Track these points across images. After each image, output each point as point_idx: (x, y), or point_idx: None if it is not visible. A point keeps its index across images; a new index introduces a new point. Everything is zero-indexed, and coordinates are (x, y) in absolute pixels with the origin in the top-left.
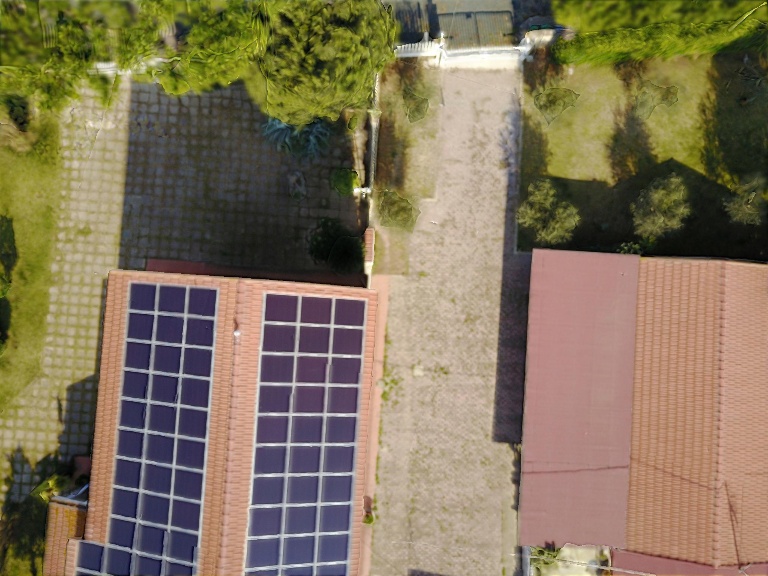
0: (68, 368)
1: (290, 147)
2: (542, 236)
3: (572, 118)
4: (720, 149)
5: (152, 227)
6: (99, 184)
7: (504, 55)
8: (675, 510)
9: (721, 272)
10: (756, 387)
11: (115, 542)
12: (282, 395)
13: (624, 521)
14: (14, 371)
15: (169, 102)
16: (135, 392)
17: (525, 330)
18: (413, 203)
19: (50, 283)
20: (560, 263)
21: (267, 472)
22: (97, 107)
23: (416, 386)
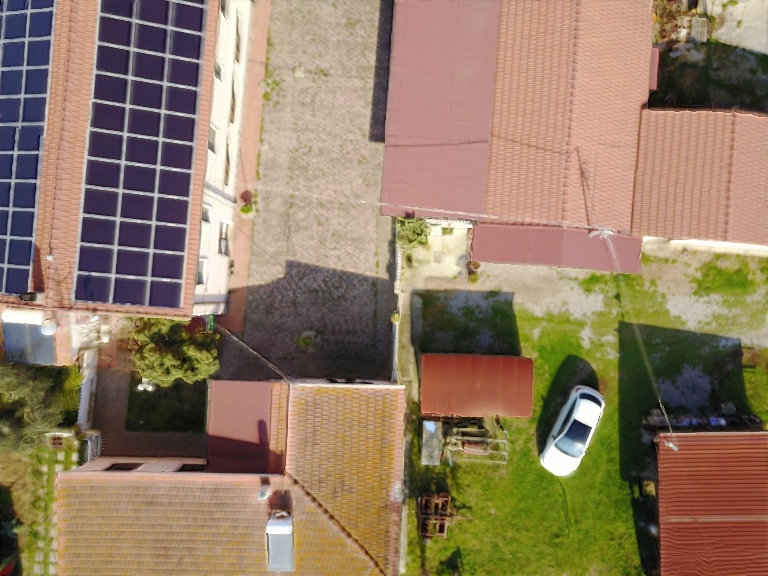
0: None
1: None
2: None
3: None
4: None
5: None
6: None
7: None
8: (530, 179)
9: None
10: (613, 62)
11: None
12: (125, 1)
13: (483, 194)
14: None
15: None
16: None
17: None
18: None
19: None
20: None
21: (110, 71)
22: None
23: (297, 87)
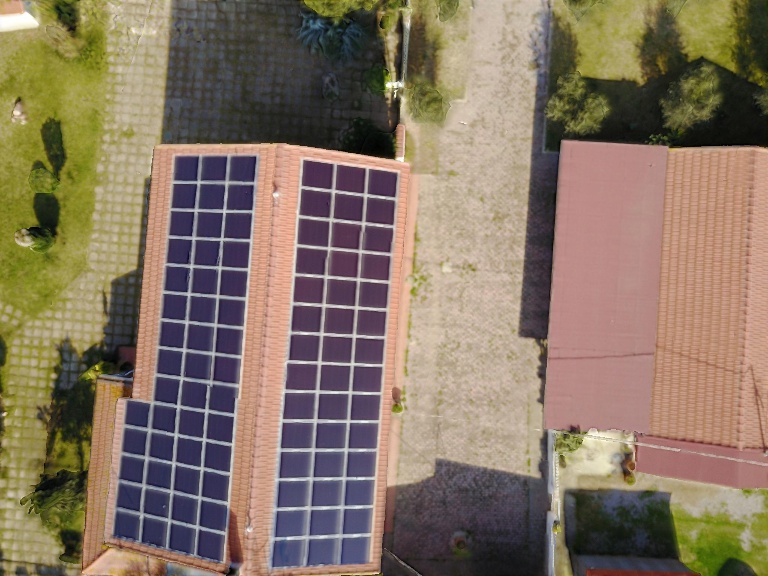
0: (113, 263)
1: (323, 48)
2: (570, 127)
3: (601, 19)
4: (751, 47)
5: (191, 128)
6: (141, 88)
7: None
8: (700, 395)
9: (750, 159)
10: None
11: (161, 399)
12: (318, 258)
13: (649, 407)
14: (62, 265)
15: (207, 8)
16: (179, 258)
17: (552, 228)
18: (443, 98)
19: (95, 182)
20: (588, 154)
21: (304, 330)
22: (139, 14)
23: (445, 282)
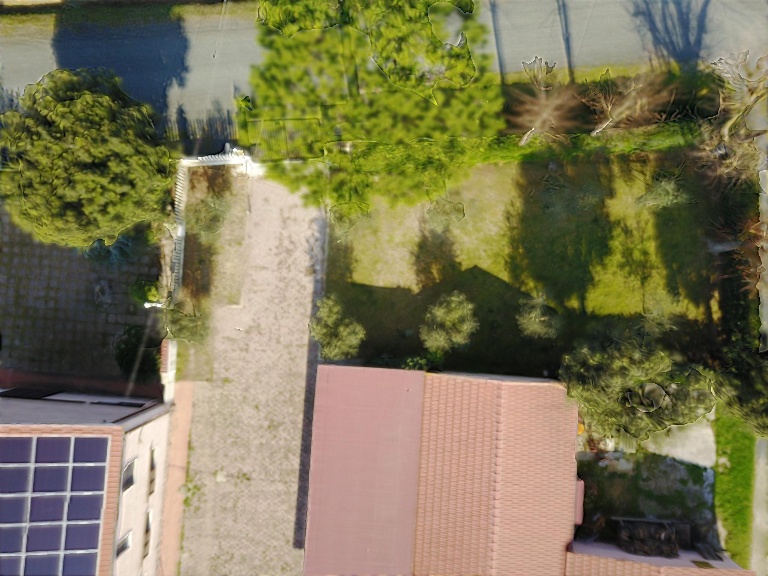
0: None
1: (93, 257)
2: (326, 352)
3: (377, 225)
4: (524, 257)
5: None
6: None
7: (311, 162)
8: None
9: (498, 393)
10: (536, 506)
11: None
12: (15, 535)
13: None
14: None
15: None
16: None
17: None
18: (204, 317)
19: None
20: (345, 379)
21: None
22: None
23: (219, 492)
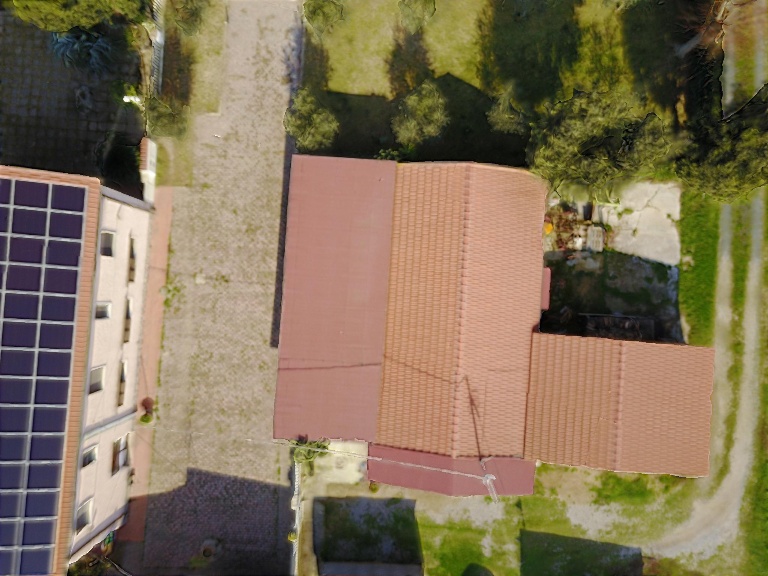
0: None
1: (73, 61)
2: (300, 142)
3: (352, 34)
4: (495, 64)
5: None
6: None
7: None
8: (421, 405)
9: (466, 174)
10: (503, 287)
11: None
12: None
13: (376, 416)
14: None
15: None
16: None
17: None
18: (182, 112)
19: None
20: (319, 169)
21: None
22: None
23: (198, 293)
